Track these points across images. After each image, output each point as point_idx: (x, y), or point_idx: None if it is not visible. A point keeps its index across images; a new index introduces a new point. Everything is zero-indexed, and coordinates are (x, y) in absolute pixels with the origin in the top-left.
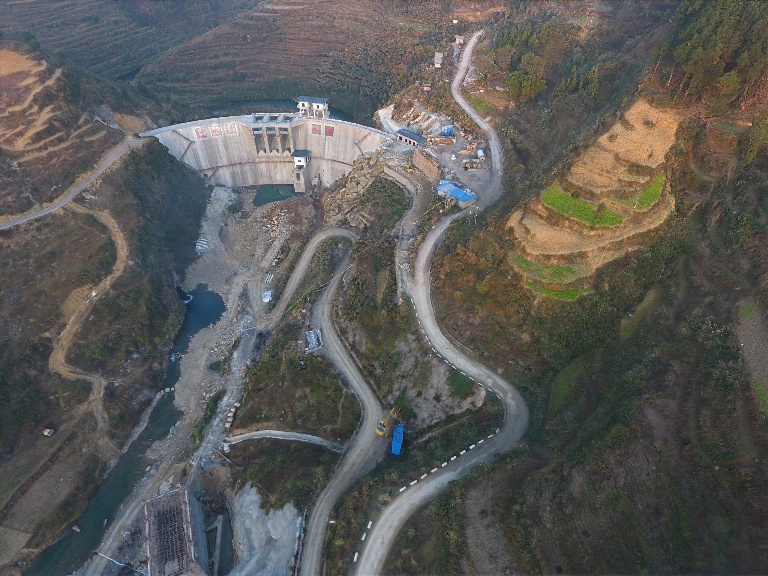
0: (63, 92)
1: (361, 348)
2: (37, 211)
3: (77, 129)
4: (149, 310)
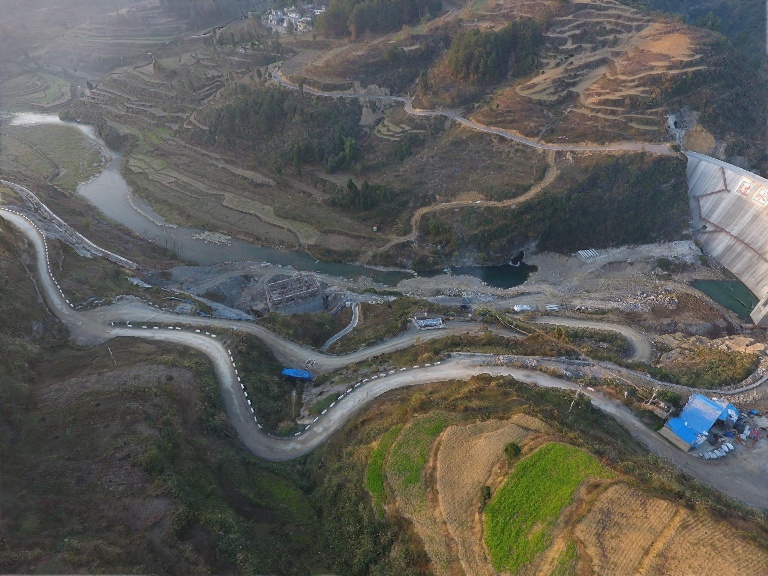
0: (671, 83)
1: None
2: (533, 142)
3: (639, 114)
4: (476, 236)
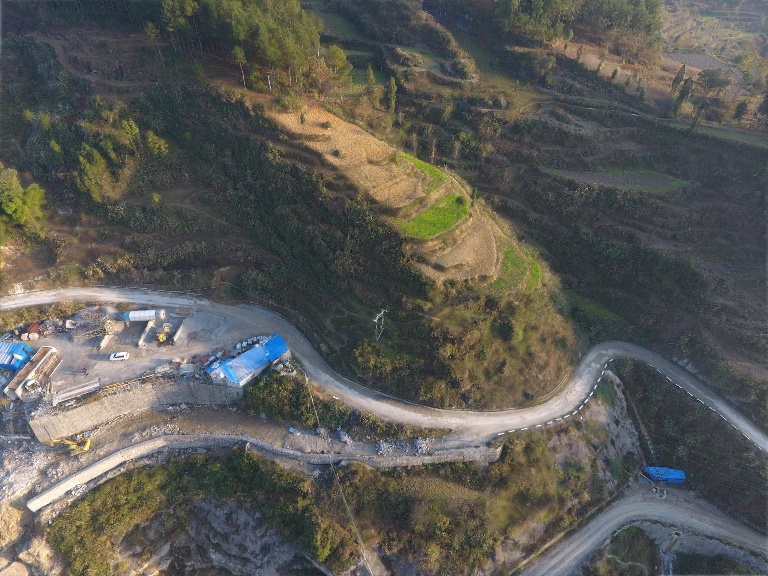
0: None
1: (539, 532)
2: None
3: None
4: None
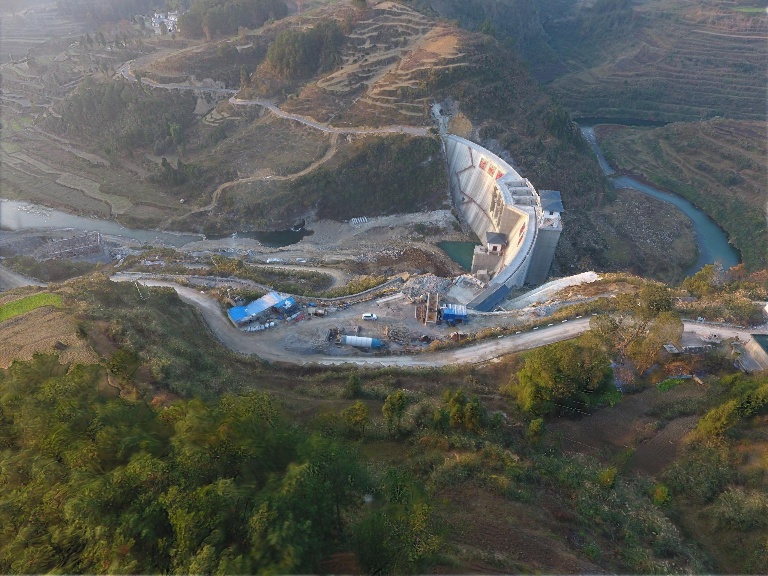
0: (435, 77)
1: None
2: (324, 126)
3: (409, 102)
4: (258, 205)
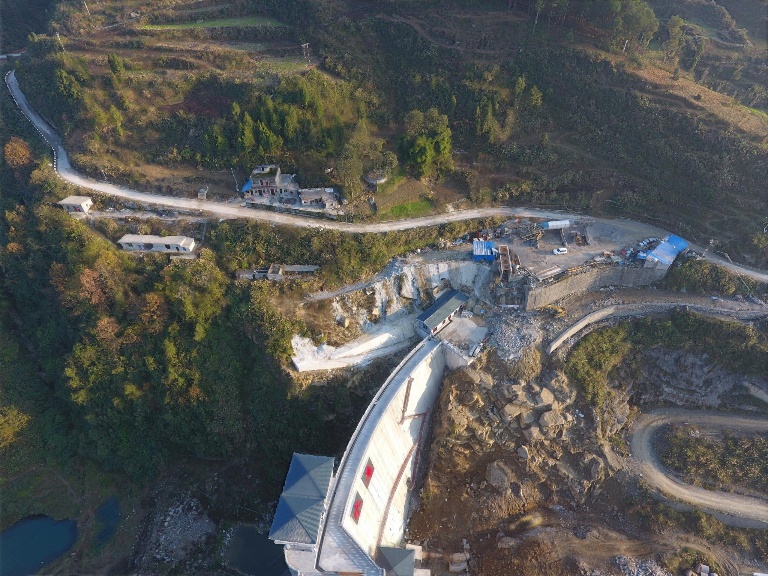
0: None
1: None
2: None
3: None
4: None
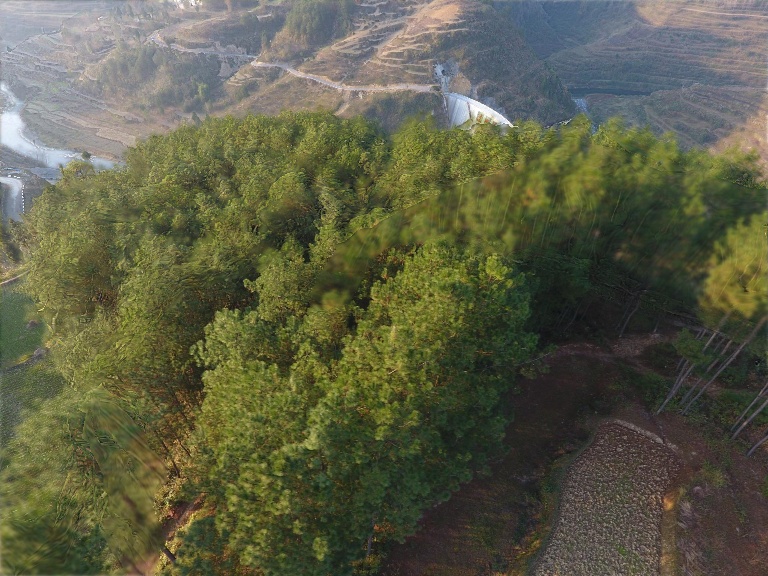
0: (438, 40)
1: None
2: (337, 85)
3: (414, 63)
4: None
